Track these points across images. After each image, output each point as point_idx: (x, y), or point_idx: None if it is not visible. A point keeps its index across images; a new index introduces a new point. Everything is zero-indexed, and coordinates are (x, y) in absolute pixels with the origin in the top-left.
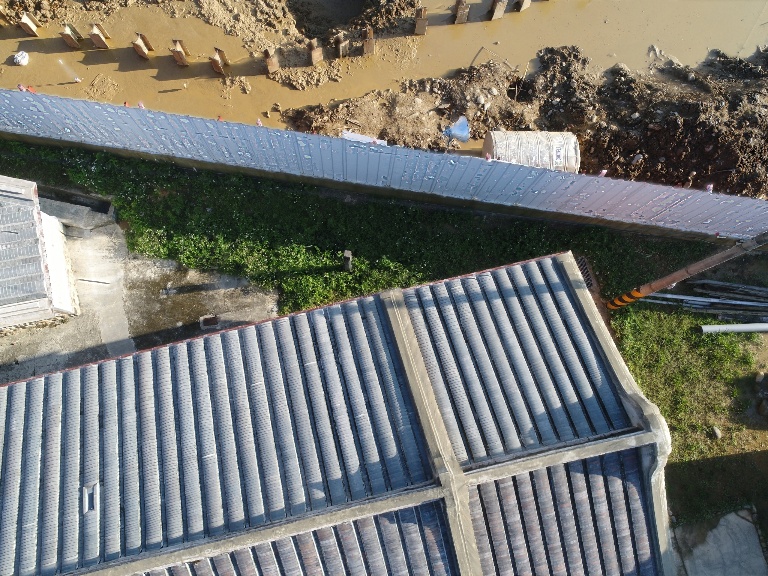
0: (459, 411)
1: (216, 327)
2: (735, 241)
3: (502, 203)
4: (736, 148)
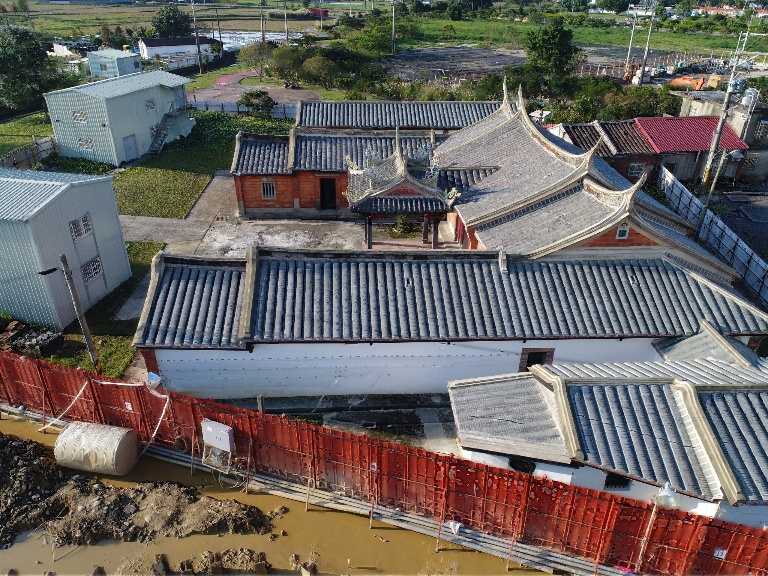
0: (236, 289)
1: (366, 422)
2: None
3: None
4: None
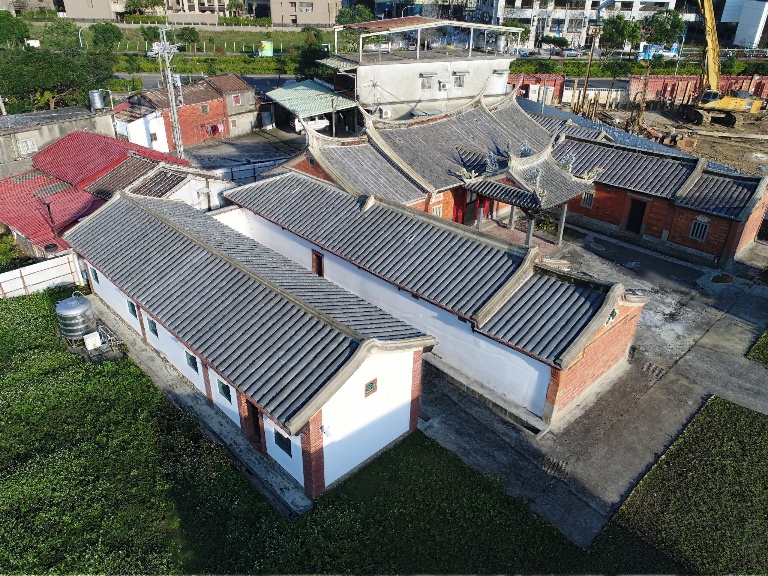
0: None
1: None
2: None
3: (767, 219)
4: None
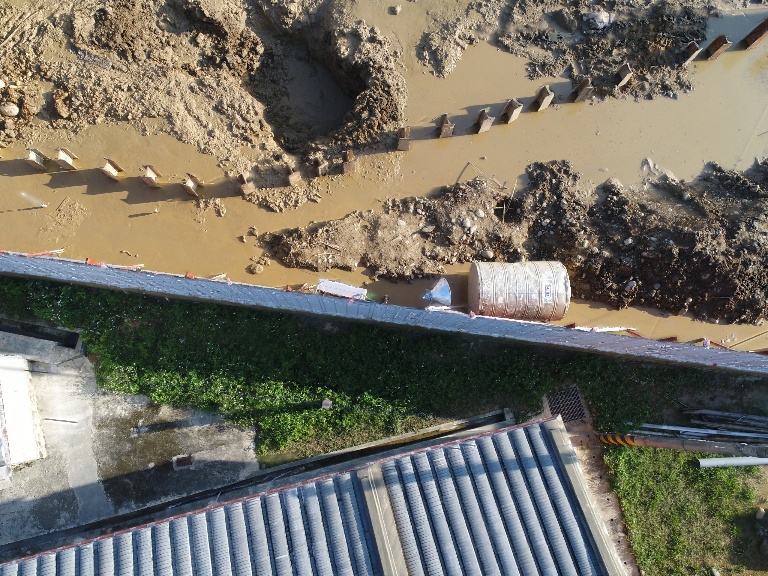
0: None
1: (190, 467)
2: (733, 371)
3: (489, 334)
4: (734, 277)
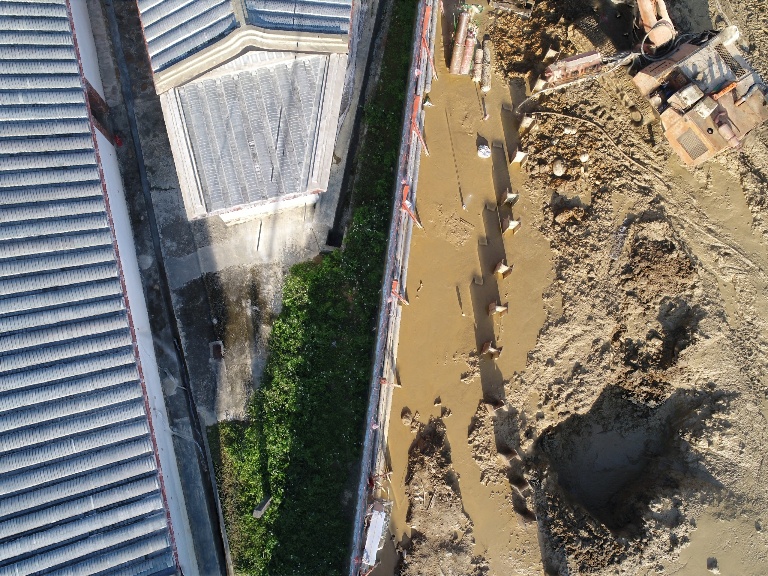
0: None
1: (211, 358)
2: None
3: None
4: None
